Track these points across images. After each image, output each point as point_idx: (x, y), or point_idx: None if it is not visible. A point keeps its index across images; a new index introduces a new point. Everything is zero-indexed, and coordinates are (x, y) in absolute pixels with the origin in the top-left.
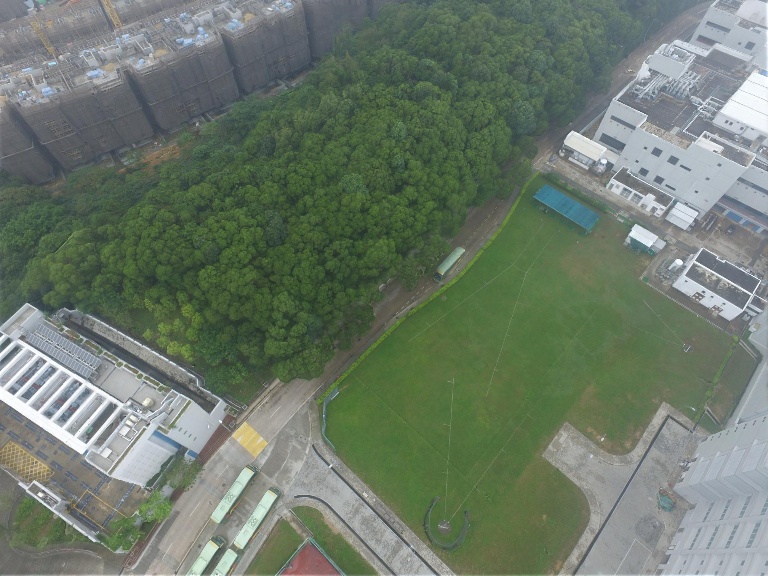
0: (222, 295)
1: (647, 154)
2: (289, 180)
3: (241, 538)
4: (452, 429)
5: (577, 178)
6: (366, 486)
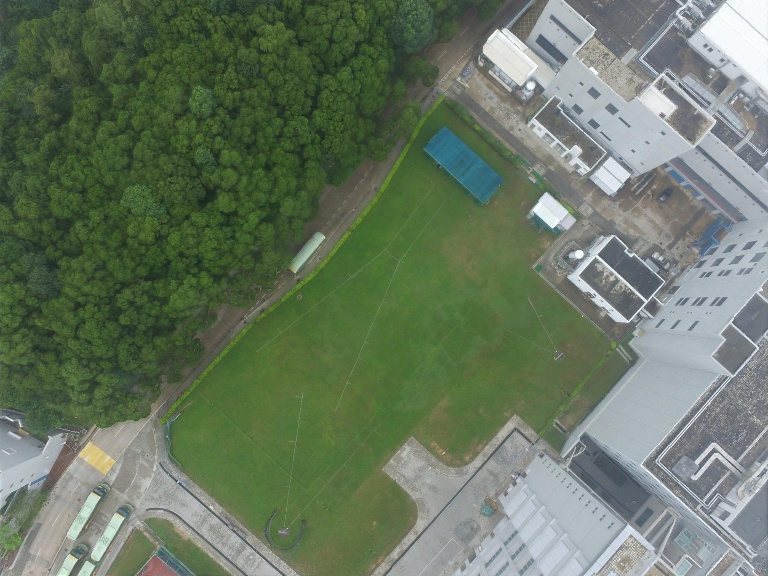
0: None
1: (583, 91)
2: (51, 197)
3: (96, 553)
4: (297, 446)
5: (493, 107)
6: (212, 499)
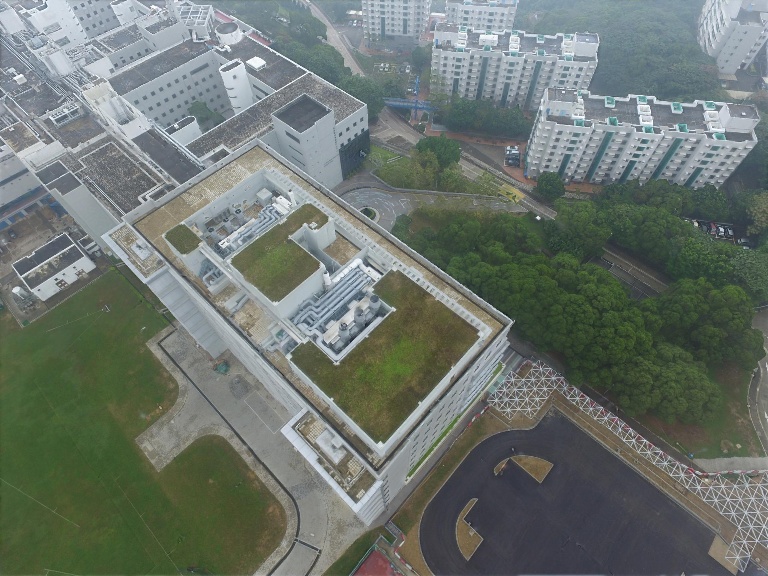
0: None
1: None
2: None
3: None
4: None
5: None
6: None
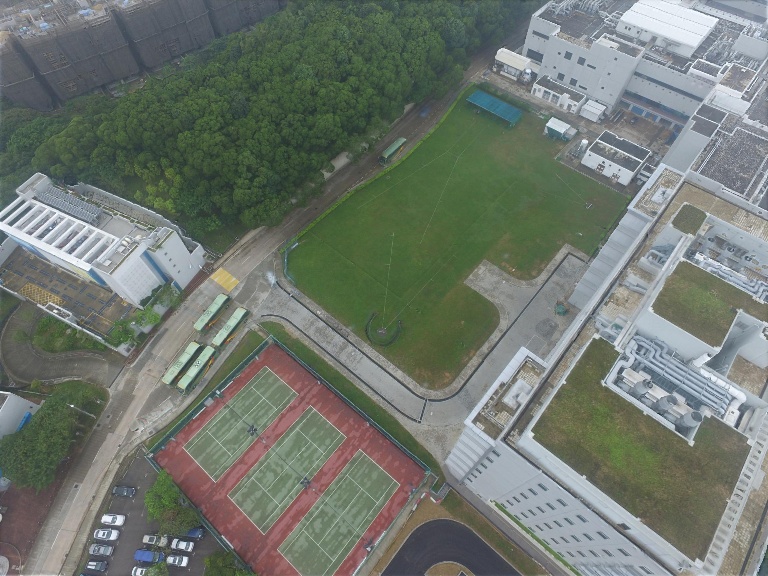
0: (196, 152)
1: (561, 59)
2: (251, 71)
3: (217, 338)
4: (391, 267)
5: (507, 87)
6: (319, 307)
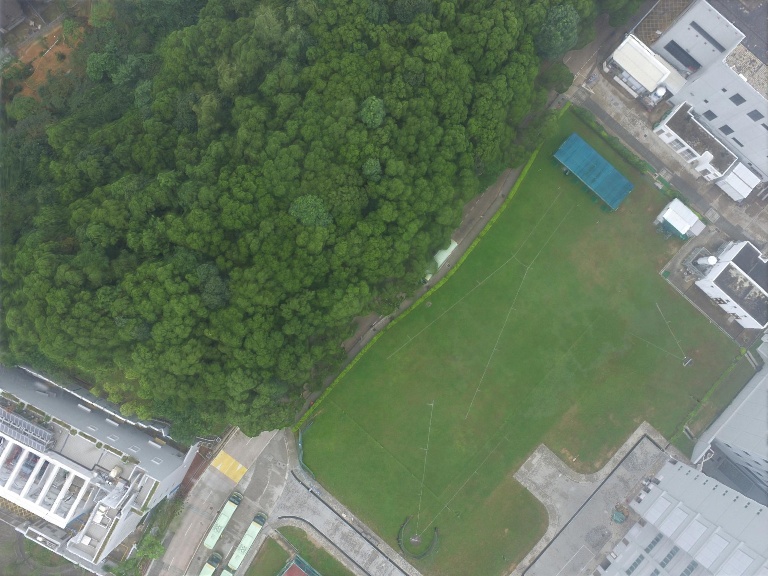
0: (165, 380)
1: (723, 98)
2: (222, 208)
3: (234, 562)
4: (428, 453)
5: (618, 113)
6: (344, 507)
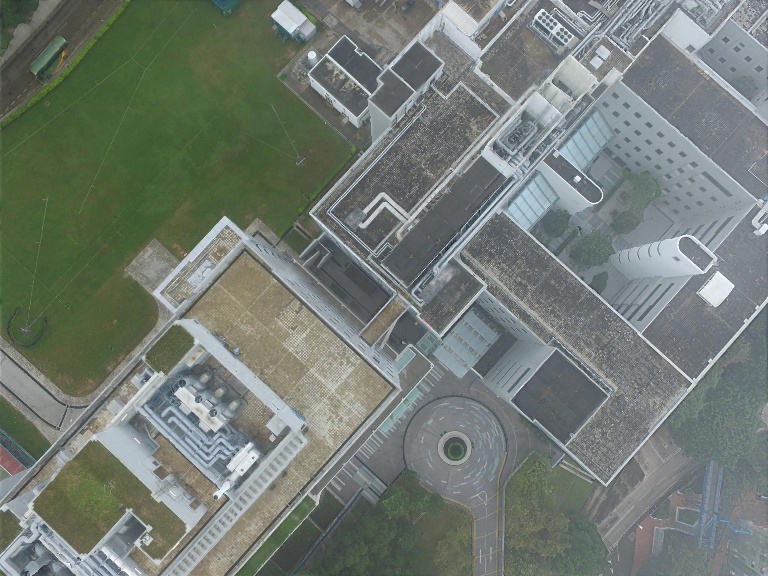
0: None
1: None
2: None
3: None
4: (41, 246)
5: None
6: None
